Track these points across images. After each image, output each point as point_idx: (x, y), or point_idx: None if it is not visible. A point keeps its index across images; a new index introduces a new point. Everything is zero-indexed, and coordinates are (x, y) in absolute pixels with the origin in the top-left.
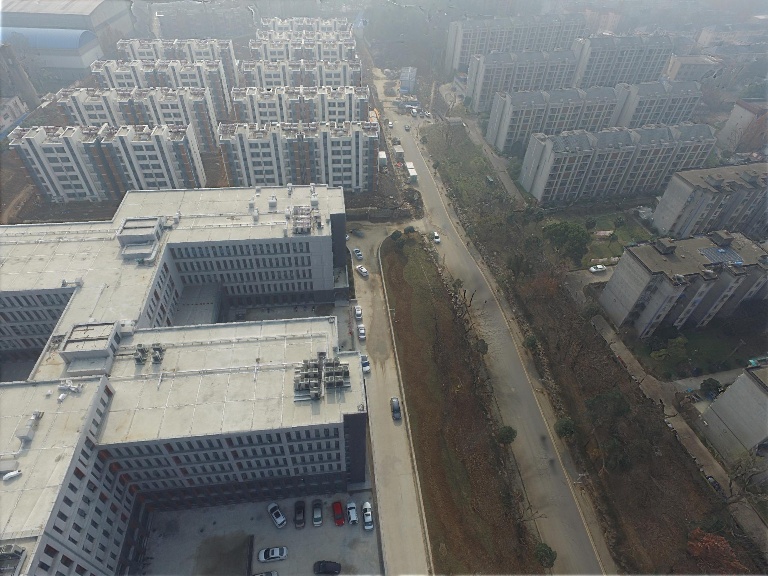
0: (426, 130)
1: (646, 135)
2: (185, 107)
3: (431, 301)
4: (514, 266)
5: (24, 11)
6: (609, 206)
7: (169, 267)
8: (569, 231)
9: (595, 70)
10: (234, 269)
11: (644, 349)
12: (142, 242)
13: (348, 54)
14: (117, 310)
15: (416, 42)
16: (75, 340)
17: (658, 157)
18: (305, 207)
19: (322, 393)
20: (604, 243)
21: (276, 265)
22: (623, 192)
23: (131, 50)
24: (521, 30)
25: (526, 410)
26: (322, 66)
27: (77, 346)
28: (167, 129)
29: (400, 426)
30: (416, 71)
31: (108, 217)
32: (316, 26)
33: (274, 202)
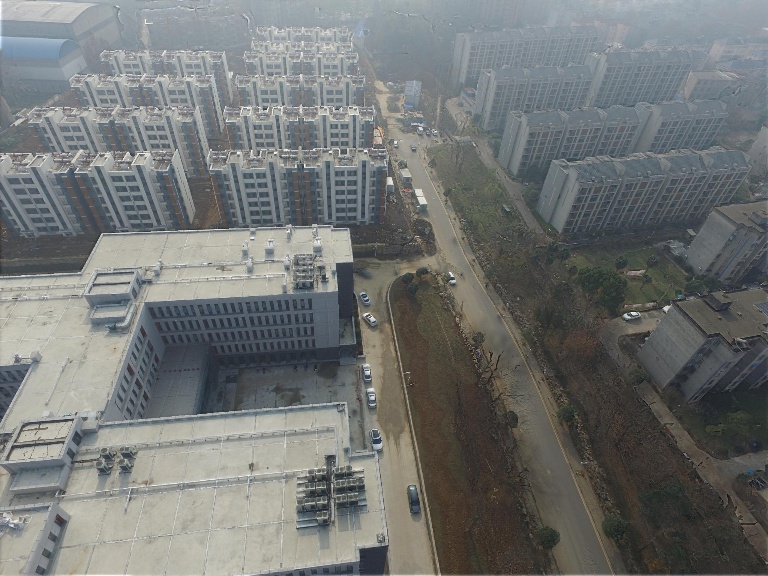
0: (434, 150)
1: (676, 162)
2: (172, 129)
3: (450, 360)
4: (544, 319)
5: (0, 18)
6: (638, 241)
7: (147, 330)
8: (604, 278)
9: (610, 86)
10: (224, 328)
11: (693, 417)
12: (115, 302)
13: (350, 68)
14: (80, 395)
15: (420, 53)
16: (22, 445)
17: (689, 186)
18: (307, 256)
19: (332, 516)
20: (636, 284)
21: (273, 323)
22: (649, 222)
23: (116, 62)
24: (531, 43)
25: (566, 499)
26: (323, 82)
27: (24, 453)
28: (150, 157)
29: (419, 522)
30: (421, 85)
31: (83, 255)
32: (315, 36)
33: (271, 248)
